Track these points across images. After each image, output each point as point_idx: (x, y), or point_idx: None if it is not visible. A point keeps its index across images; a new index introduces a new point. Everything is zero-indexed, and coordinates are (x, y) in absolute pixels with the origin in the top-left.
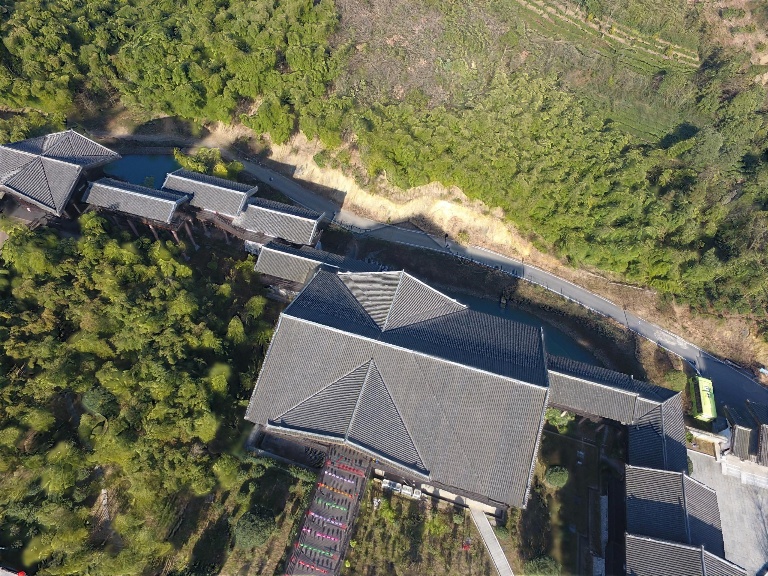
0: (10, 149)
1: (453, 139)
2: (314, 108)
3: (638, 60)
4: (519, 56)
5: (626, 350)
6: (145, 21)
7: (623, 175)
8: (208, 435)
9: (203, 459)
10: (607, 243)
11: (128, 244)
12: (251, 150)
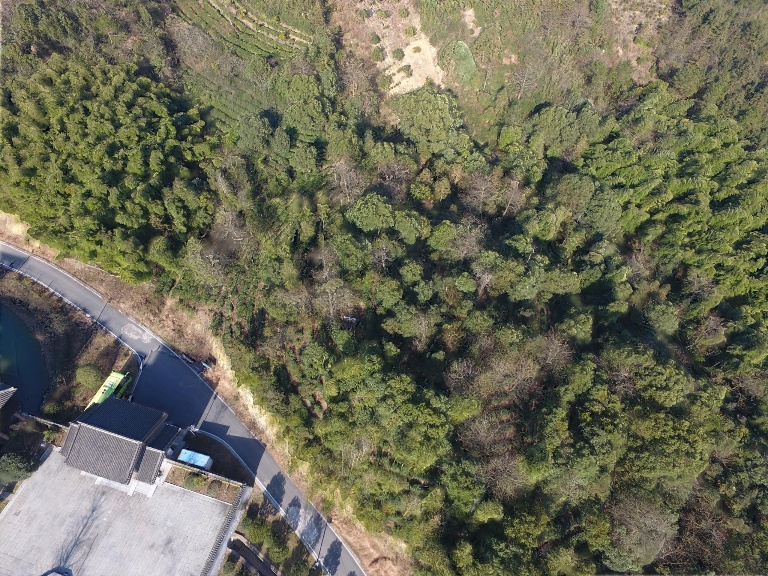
0: None
1: None
2: None
3: (253, 45)
4: (124, 41)
5: (57, 345)
6: None
7: (111, 162)
8: None
9: None
10: (70, 233)
11: None
12: None
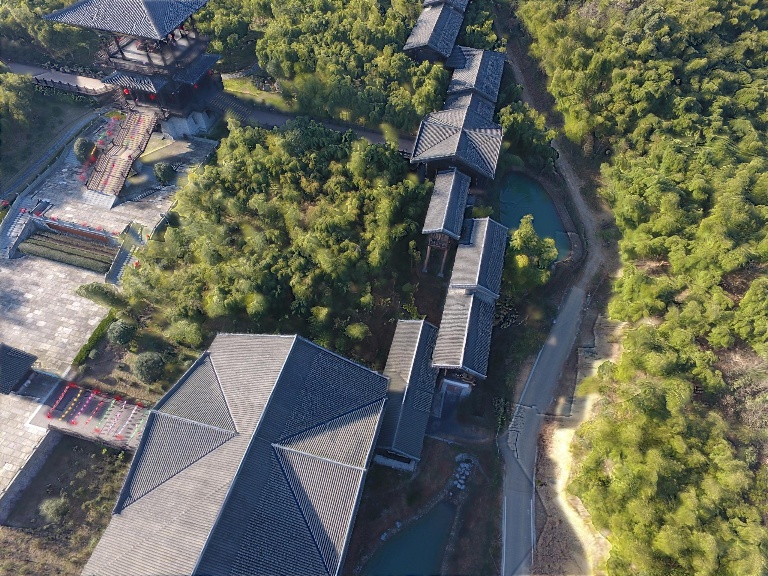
0: (466, 112)
1: (698, 573)
2: (675, 337)
3: None
4: None
5: None
6: (739, 143)
7: None
8: (210, 311)
9: (189, 311)
10: None
11: (407, 216)
12: (606, 296)
